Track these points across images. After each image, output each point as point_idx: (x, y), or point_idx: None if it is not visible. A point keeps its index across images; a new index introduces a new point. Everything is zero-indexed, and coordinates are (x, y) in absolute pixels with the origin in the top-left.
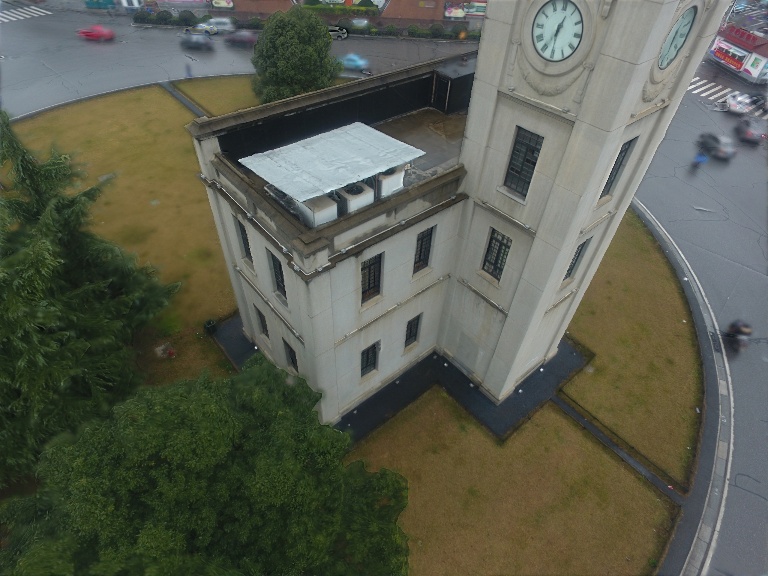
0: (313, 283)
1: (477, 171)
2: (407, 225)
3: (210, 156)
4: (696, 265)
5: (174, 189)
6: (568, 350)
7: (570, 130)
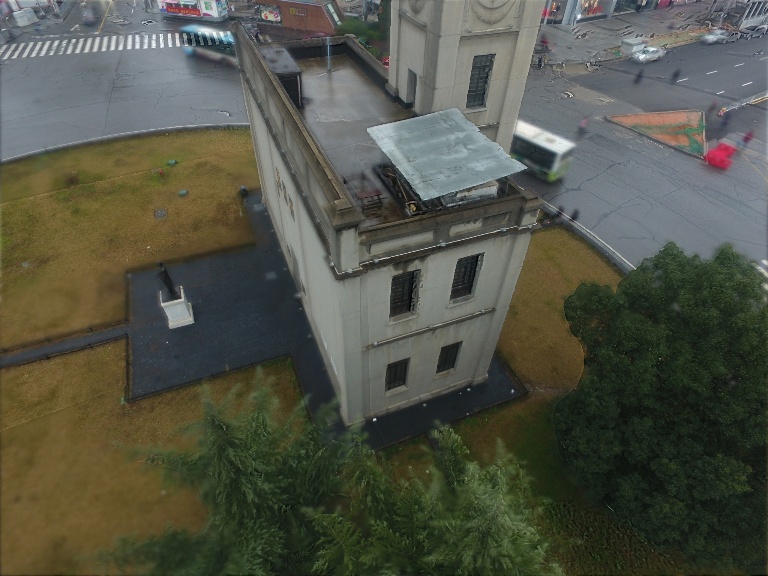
0: None
1: None
2: None
3: None
4: None
5: None
6: None
7: (514, 38)
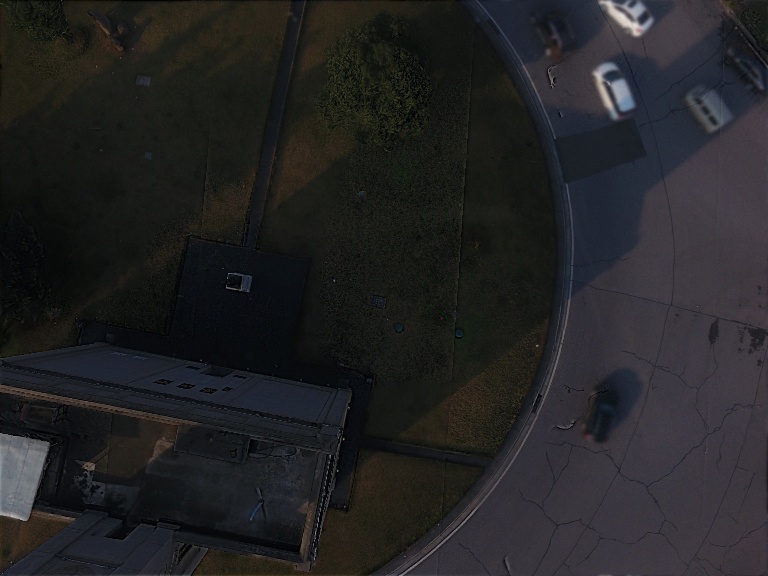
0: None
1: None
2: None
3: None
4: None
5: (172, 149)
6: None
7: None
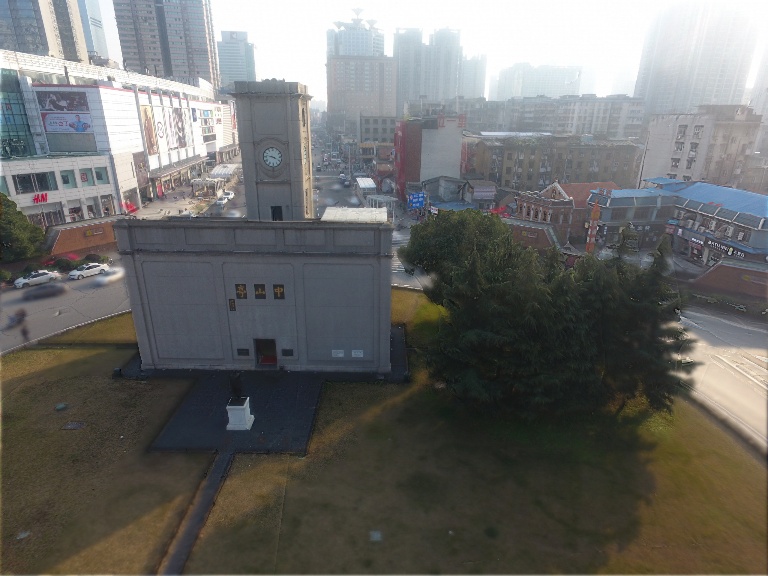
0: None
1: None
2: None
3: None
4: None
5: (337, 550)
6: None
7: None
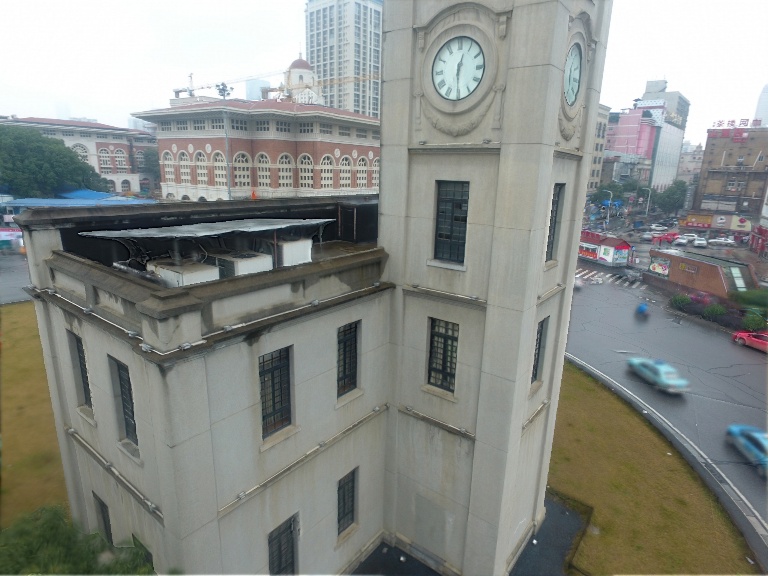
0: (175, 374)
1: (400, 249)
2: (321, 306)
3: (45, 254)
4: (647, 399)
5: (22, 390)
6: (557, 509)
7: (497, 161)
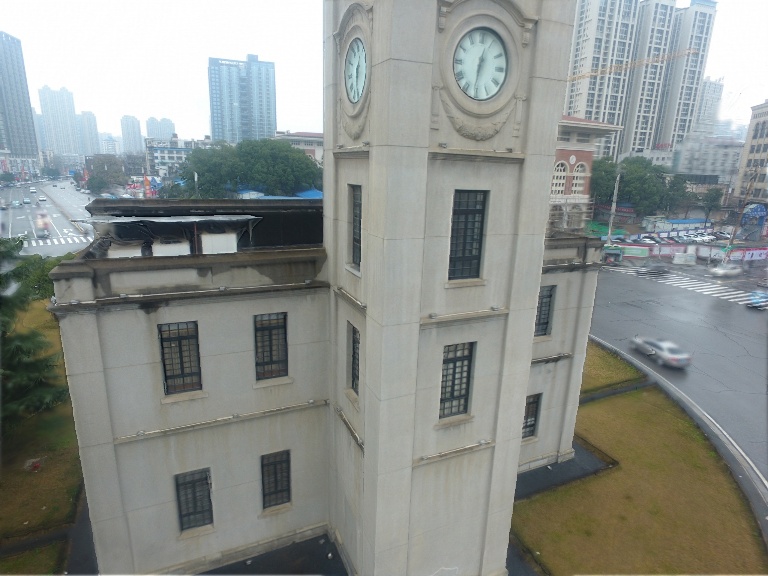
0: (68, 322)
1: (331, 250)
2: (226, 292)
3: None
4: None
5: None
6: None
7: None
